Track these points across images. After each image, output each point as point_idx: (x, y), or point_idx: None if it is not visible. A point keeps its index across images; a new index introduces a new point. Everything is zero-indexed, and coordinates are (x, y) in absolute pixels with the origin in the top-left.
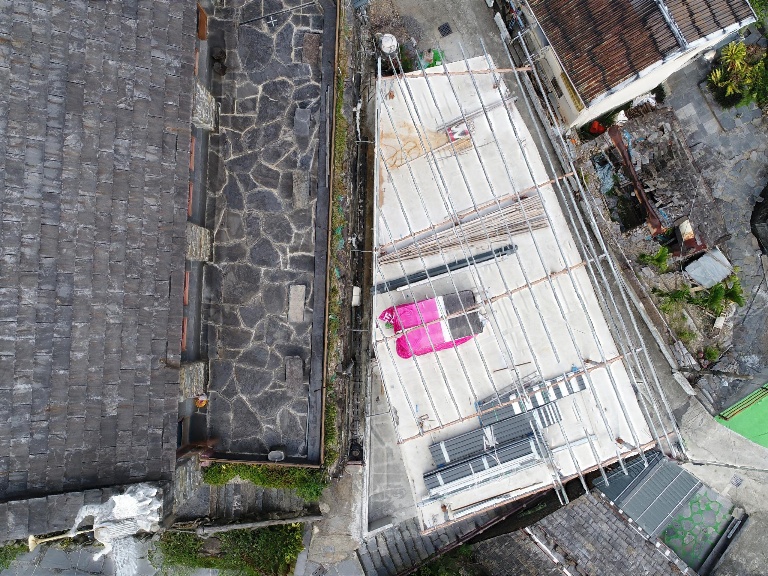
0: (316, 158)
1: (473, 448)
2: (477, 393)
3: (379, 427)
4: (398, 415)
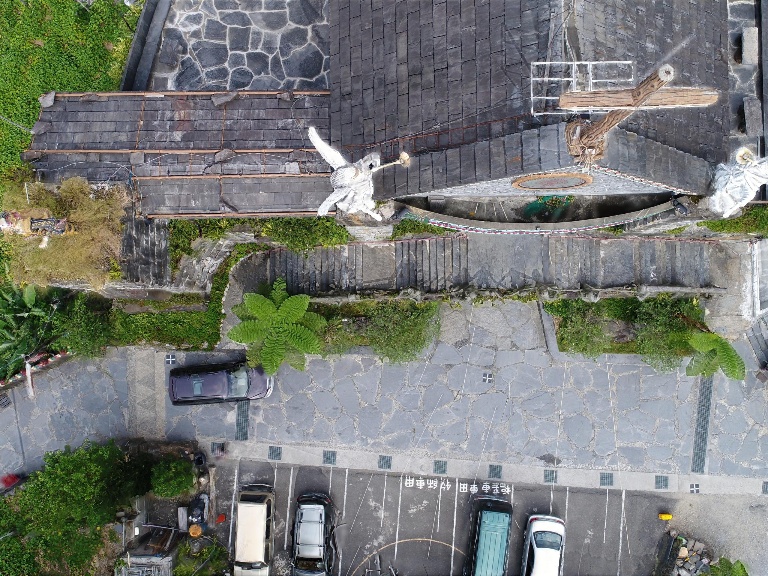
0: None
1: None
2: None
3: None
4: None
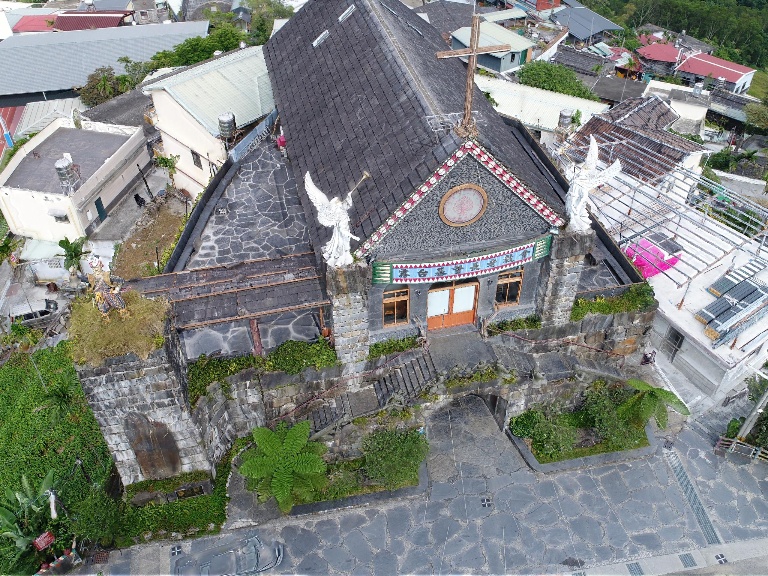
0: None
1: (724, 307)
2: (703, 285)
3: None
4: (661, 308)
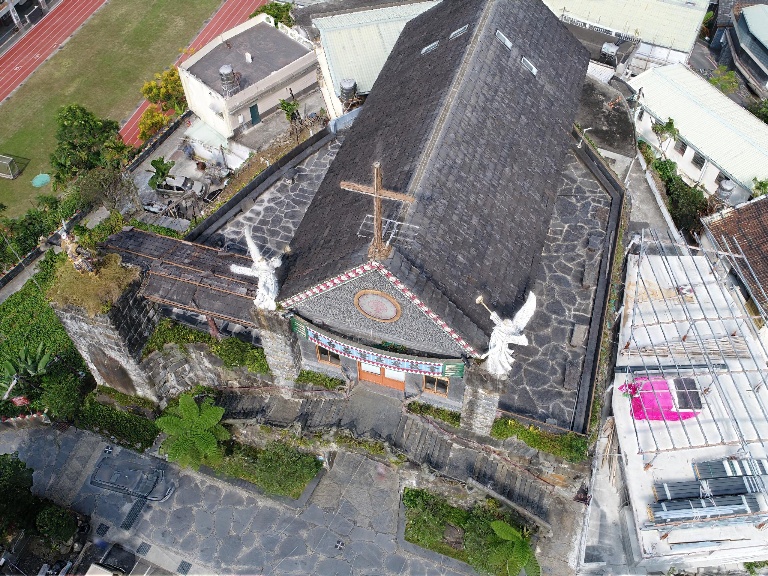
0: (598, 266)
1: (691, 493)
2: (694, 457)
3: (596, 492)
4: (628, 458)
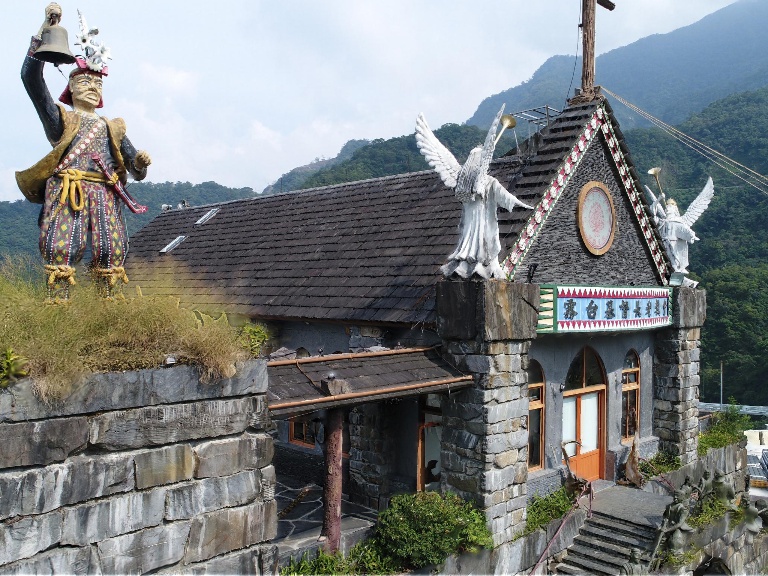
0: None
1: (759, 470)
2: None
3: None
4: None
